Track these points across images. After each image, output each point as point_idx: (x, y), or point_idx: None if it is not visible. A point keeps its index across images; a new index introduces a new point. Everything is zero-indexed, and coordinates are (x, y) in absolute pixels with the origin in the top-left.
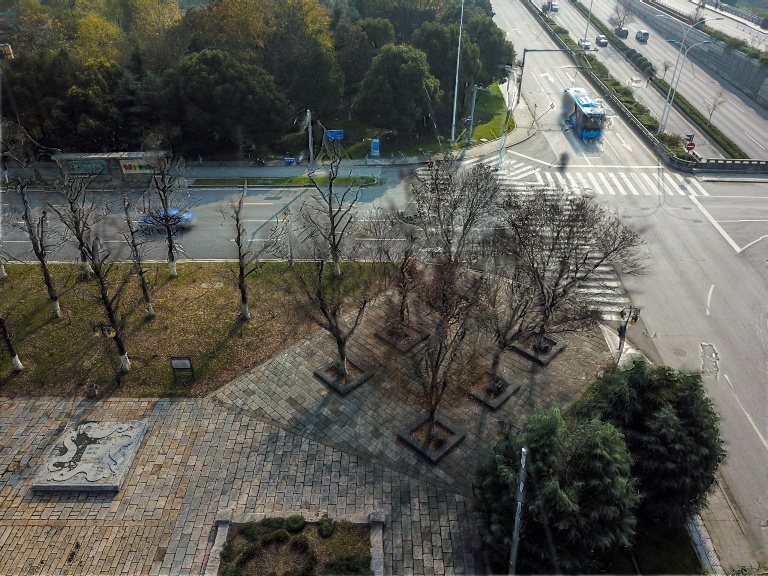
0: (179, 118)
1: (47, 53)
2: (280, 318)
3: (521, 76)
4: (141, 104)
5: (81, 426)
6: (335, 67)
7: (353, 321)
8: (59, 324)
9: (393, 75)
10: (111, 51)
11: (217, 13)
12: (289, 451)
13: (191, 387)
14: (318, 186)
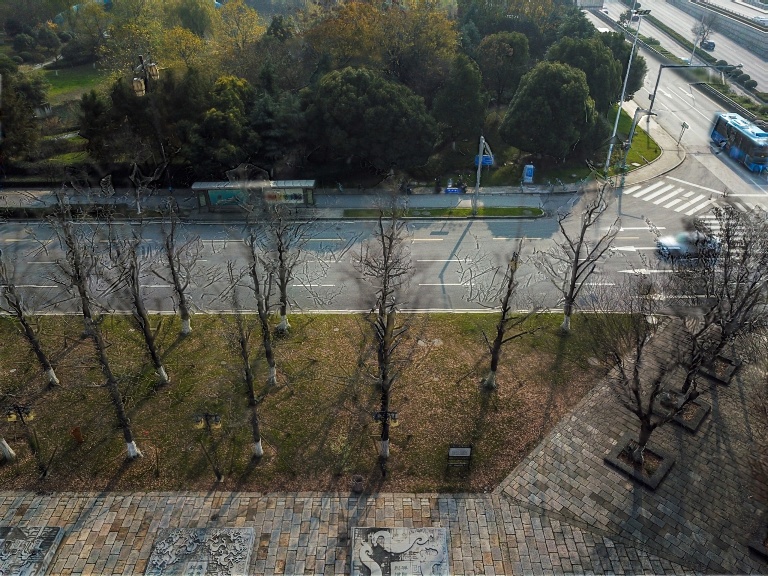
0: (318, 142)
1: (176, 71)
2: (529, 386)
3: (654, 93)
4: (279, 127)
5: (371, 536)
6: (481, 86)
7: (612, 389)
8: (280, 393)
9: (552, 96)
10: (241, 69)
11: (336, 26)
12: (631, 570)
13: (469, 478)
14: (567, 233)
